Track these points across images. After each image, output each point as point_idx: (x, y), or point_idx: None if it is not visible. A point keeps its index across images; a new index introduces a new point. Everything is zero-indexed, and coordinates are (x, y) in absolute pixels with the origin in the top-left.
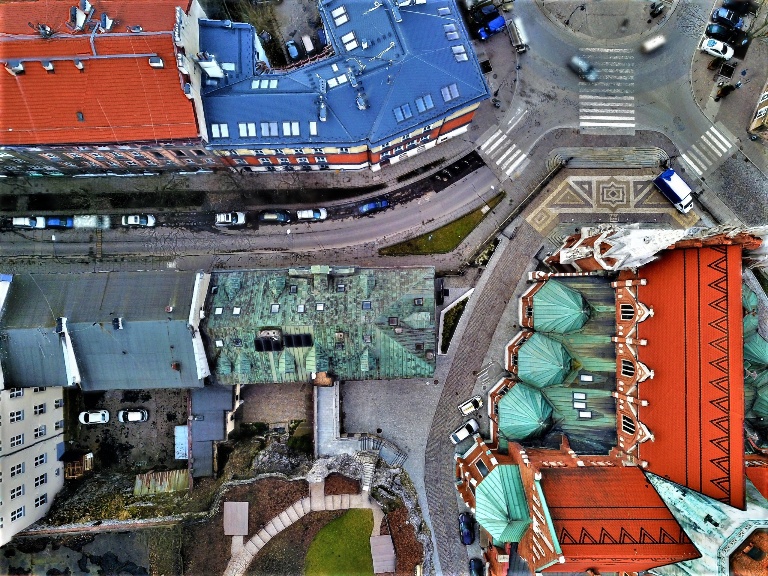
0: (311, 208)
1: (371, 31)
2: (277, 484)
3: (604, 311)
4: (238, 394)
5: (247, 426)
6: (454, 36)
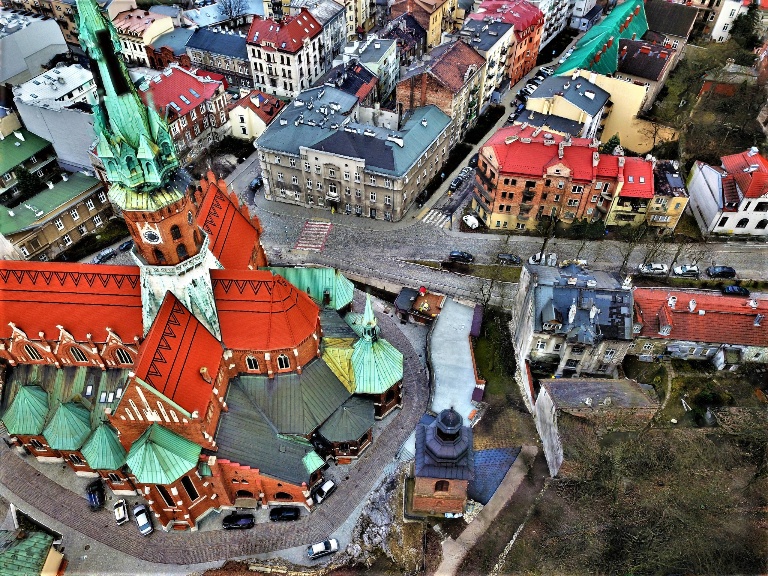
0: None
1: None
2: None
3: (36, 374)
4: None
5: None
6: None
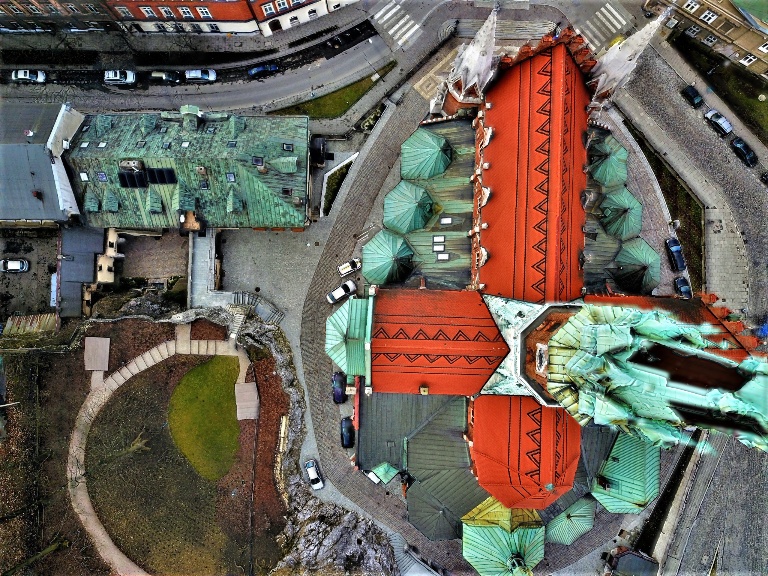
0: (200, 68)
1: None
2: (142, 325)
3: (465, 153)
4: (114, 242)
5: (127, 280)
6: None
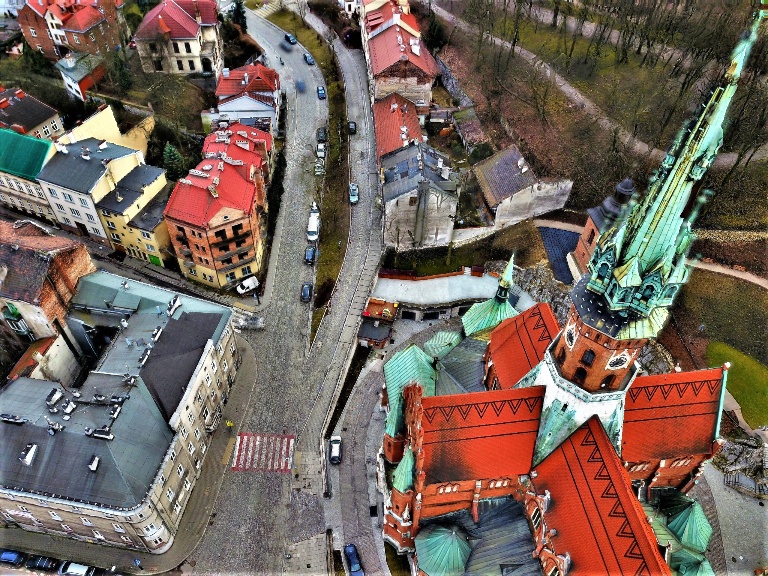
0: None
1: None
2: None
3: None
4: None
5: None
6: None
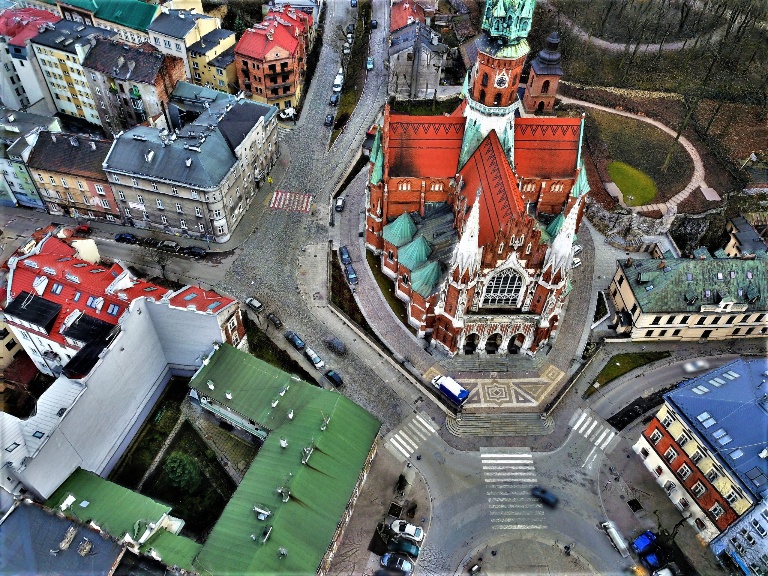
0: None
1: None
2: (692, 211)
3: None
4: None
5: None
6: (717, 435)
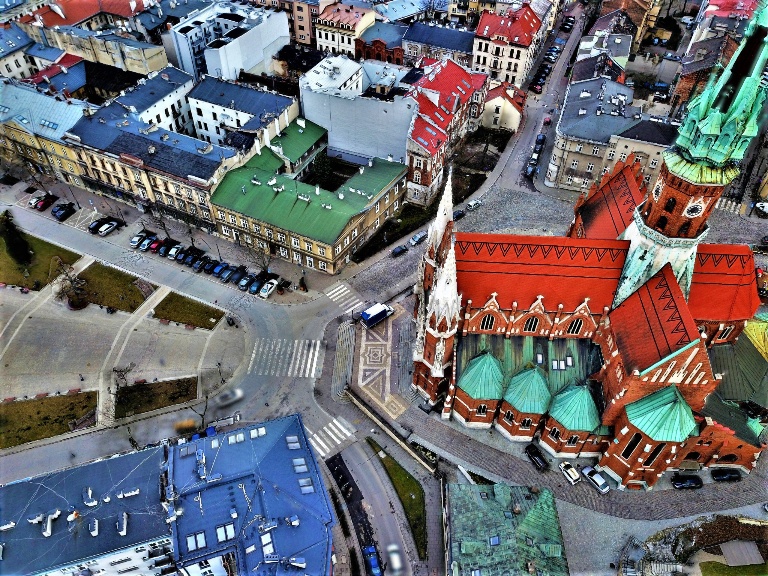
0: None
1: (221, 508)
2: None
3: (485, 343)
4: None
5: None
6: (240, 437)
